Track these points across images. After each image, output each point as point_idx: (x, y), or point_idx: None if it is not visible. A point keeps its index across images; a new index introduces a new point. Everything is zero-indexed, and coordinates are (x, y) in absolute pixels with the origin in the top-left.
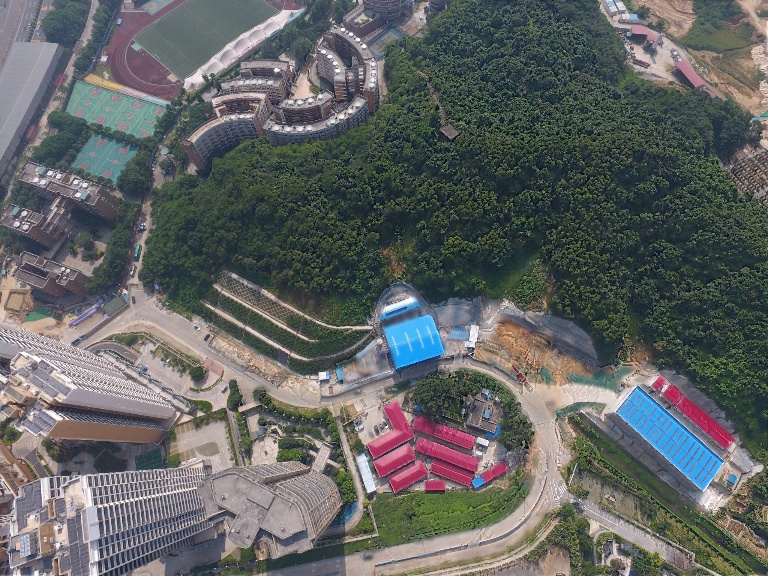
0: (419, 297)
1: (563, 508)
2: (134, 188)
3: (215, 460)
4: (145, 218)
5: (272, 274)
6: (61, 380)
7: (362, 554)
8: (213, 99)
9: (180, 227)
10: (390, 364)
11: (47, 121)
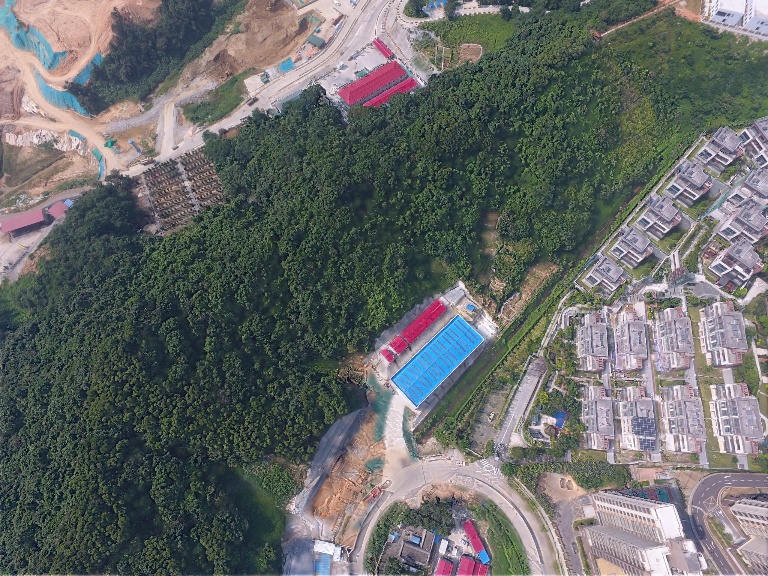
0: None
1: None
2: None
3: None
4: None
5: None
6: None
7: None
8: None
9: None
10: None
11: None
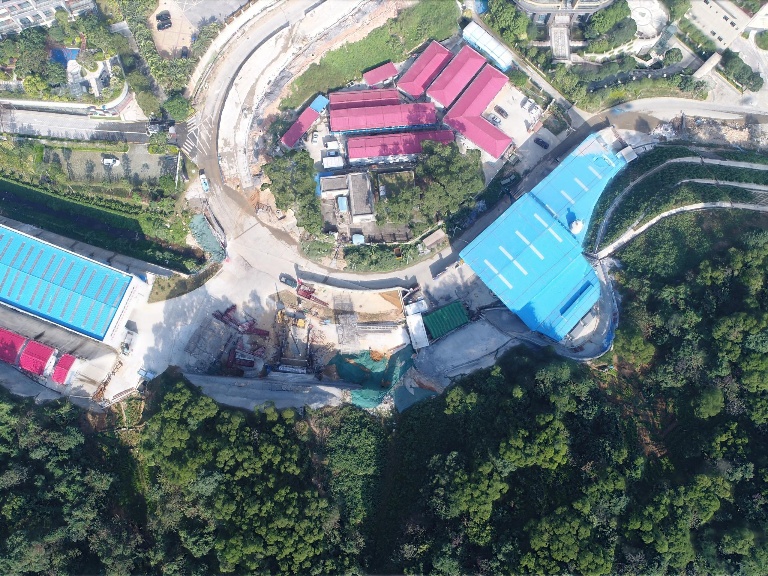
0: None
1: None
2: None
3: None
4: None
5: None
6: None
7: None
8: None
9: None
10: (539, 201)
11: None
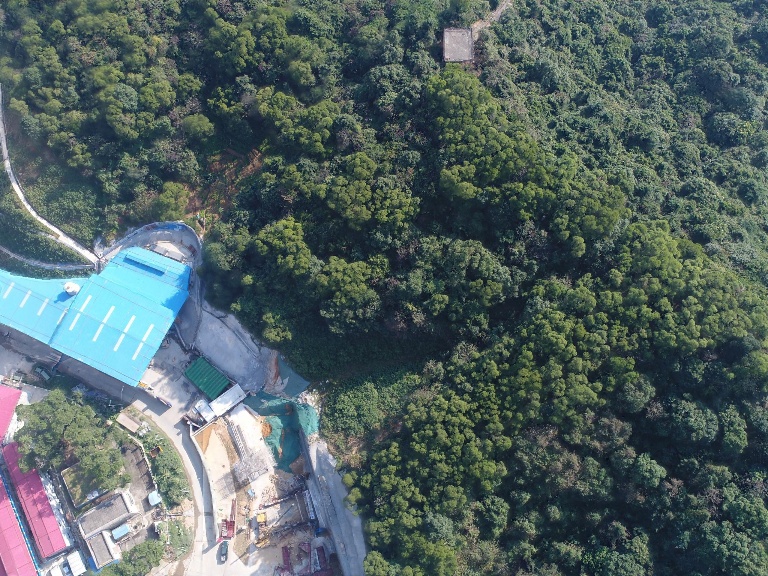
0: None
1: None
2: None
3: None
4: None
5: (1, 60)
6: None
7: None
8: None
9: None
10: None
11: None
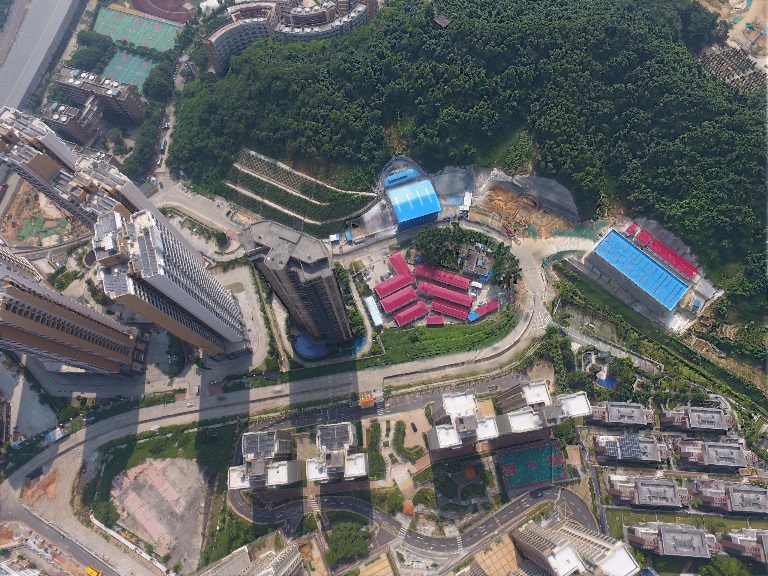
0: (418, 169)
1: (547, 327)
2: (158, 91)
3: (241, 296)
4: (169, 119)
5: (287, 142)
6: (118, 175)
7: (372, 370)
8: (229, 8)
9: (203, 111)
10: (393, 221)
11: (76, 39)
